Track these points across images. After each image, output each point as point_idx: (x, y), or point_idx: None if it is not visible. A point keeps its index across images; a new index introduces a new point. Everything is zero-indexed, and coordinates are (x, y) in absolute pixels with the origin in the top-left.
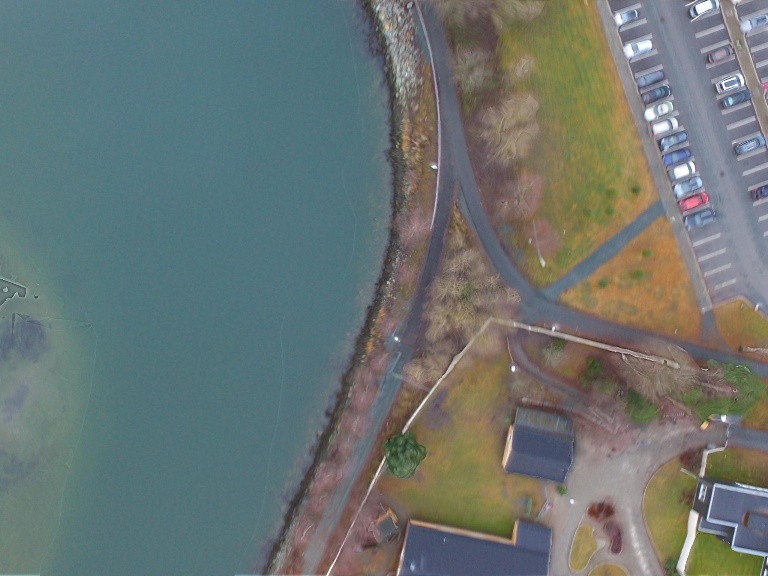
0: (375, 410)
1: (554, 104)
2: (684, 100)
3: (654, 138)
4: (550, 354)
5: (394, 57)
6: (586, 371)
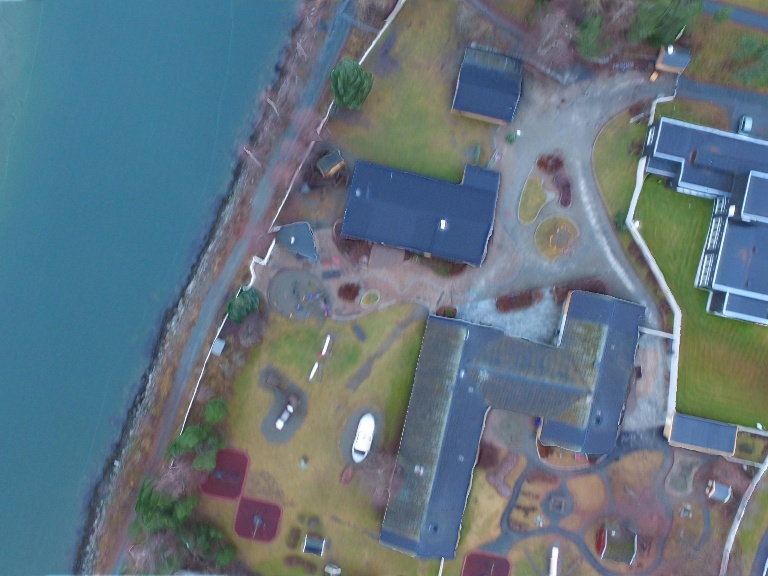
0: (323, 55)
1: None
2: None
3: None
4: None
5: None
6: (534, 7)
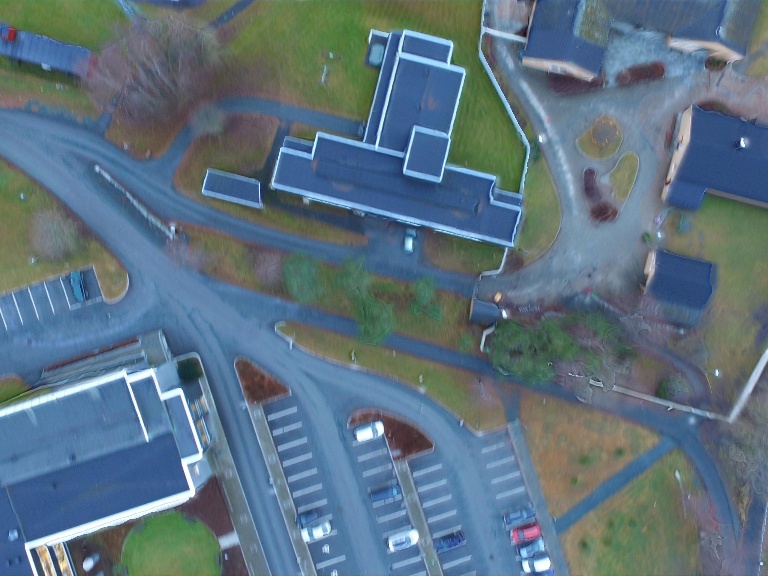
0: None
1: None
2: None
3: None
4: (678, 385)
5: None
6: None
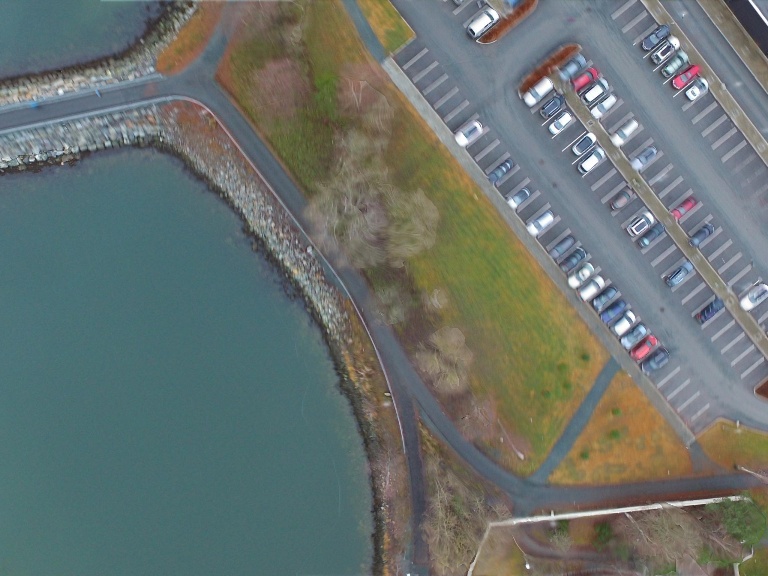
0: None
1: (479, 305)
2: (602, 254)
3: (585, 302)
4: (557, 540)
5: (312, 297)
6: (597, 538)
